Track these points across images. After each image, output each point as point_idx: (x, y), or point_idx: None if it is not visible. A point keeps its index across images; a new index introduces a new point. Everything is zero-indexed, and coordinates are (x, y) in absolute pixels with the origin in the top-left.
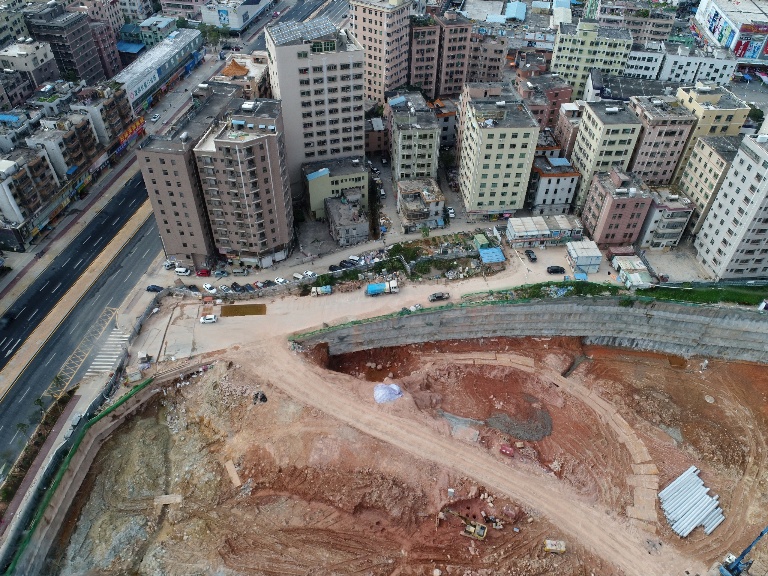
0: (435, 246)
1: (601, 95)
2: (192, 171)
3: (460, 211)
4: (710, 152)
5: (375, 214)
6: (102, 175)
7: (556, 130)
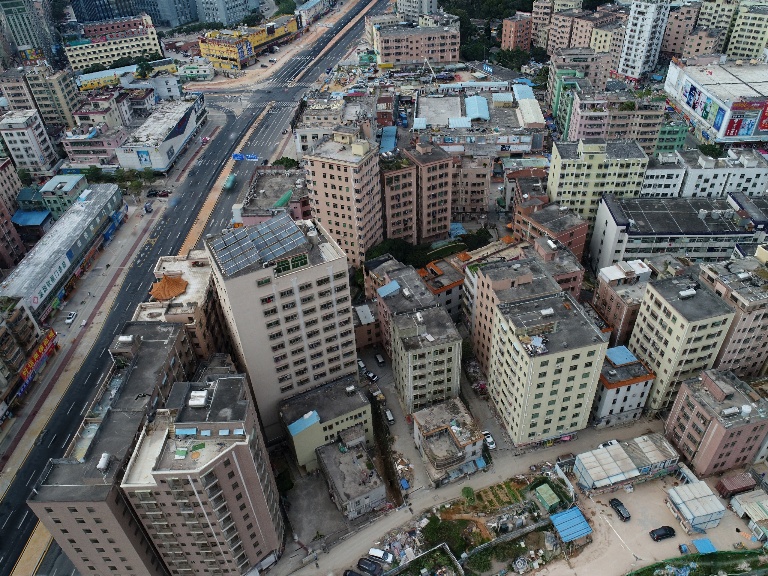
0: (485, 513)
1: (628, 232)
2: (123, 508)
3: (500, 435)
4: None
5: (386, 453)
6: (1, 432)
7: (596, 299)
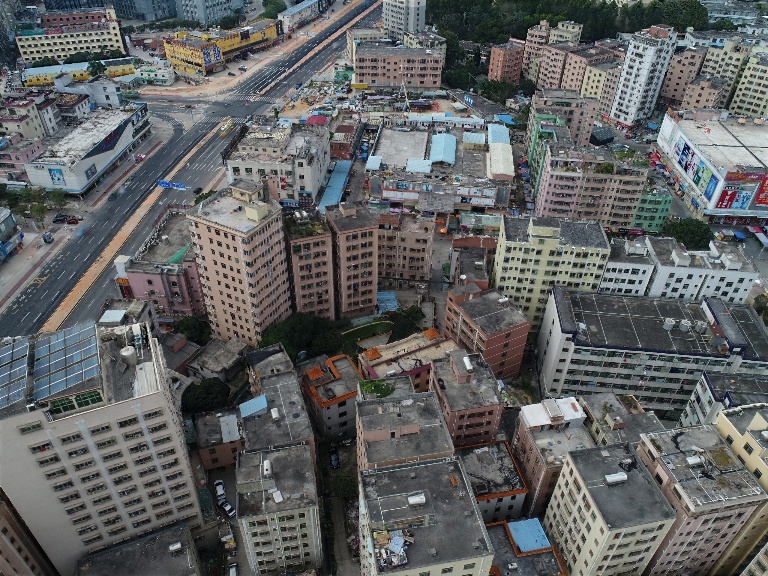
0: None
1: (574, 341)
2: None
3: None
4: None
5: None
6: None
7: (516, 440)
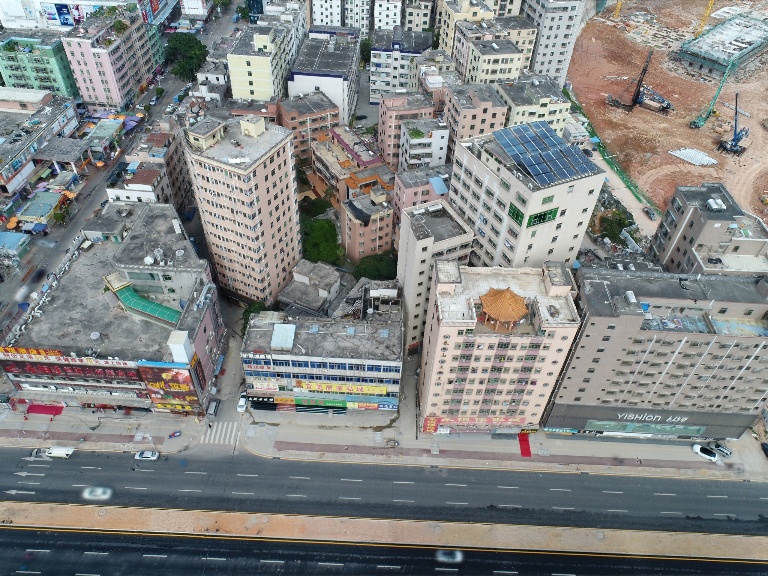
0: None
1: (346, 78)
2: None
3: None
4: (518, 32)
5: None
6: None
7: None
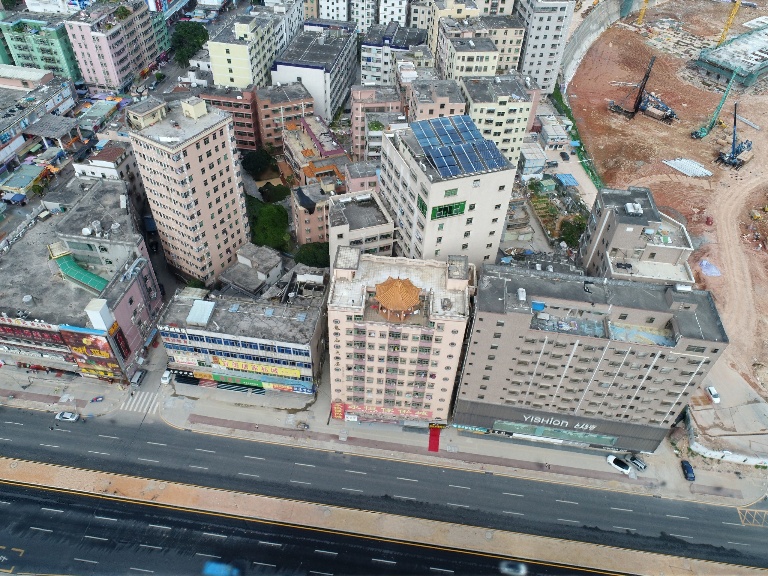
0: (556, 215)
1: (328, 70)
2: None
3: None
4: (505, 31)
5: None
6: None
7: (406, 102)
